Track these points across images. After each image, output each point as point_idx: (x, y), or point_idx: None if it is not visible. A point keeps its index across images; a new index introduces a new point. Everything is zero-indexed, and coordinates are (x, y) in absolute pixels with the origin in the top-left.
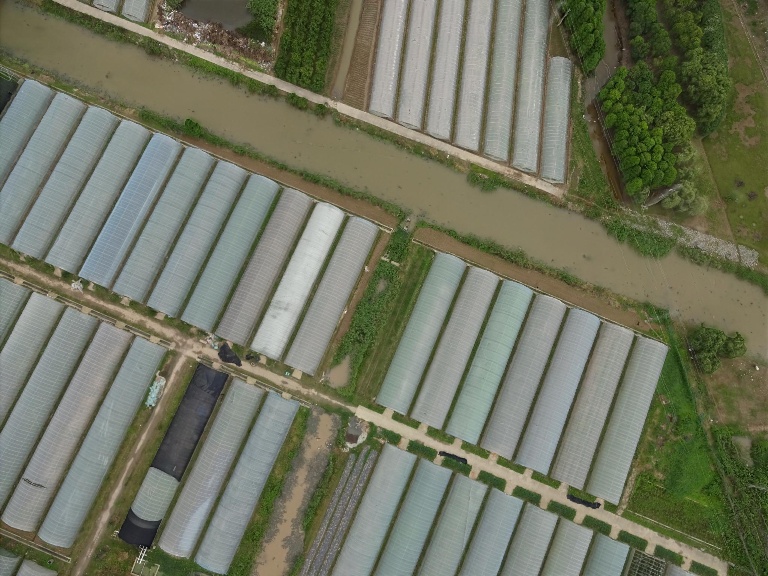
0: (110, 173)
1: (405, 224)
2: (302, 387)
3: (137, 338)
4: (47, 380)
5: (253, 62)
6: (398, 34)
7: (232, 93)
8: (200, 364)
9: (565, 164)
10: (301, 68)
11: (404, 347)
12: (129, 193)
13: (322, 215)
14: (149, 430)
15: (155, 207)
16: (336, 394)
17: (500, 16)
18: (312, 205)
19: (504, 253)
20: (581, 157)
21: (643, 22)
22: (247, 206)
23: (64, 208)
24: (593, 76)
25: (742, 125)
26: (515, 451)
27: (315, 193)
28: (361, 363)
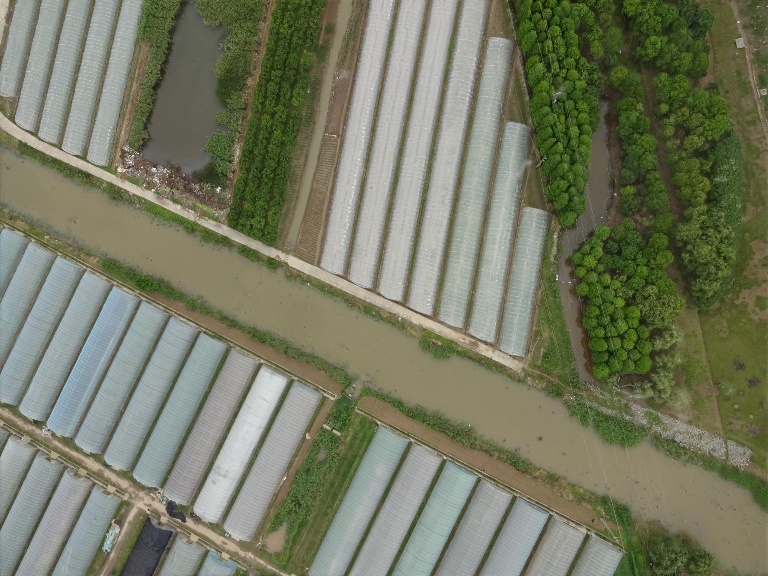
0: (72, 327)
1: (350, 390)
2: (240, 549)
3: (94, 489)
4: (19, 522)
5: (209, 209)
6: (355, 179)
7: (188, 242)
8: (147, 520)
9: (528, 333)
10: (252, 220)
11: (337, 524)
12: (89, 348)
13: (264, 382)
14: (105, 573)
15: (113, 361)
16: (271, 560)
17: (469, 157)
18: (258, 366)
19: (450, 432)
20: (548, 326)
21: (637, 169)
22: (193, 368)
23: (35, 358)
24: (573, 228)
25: (753, 294)
26: None
27: (262, 353)
28: (296, 533)
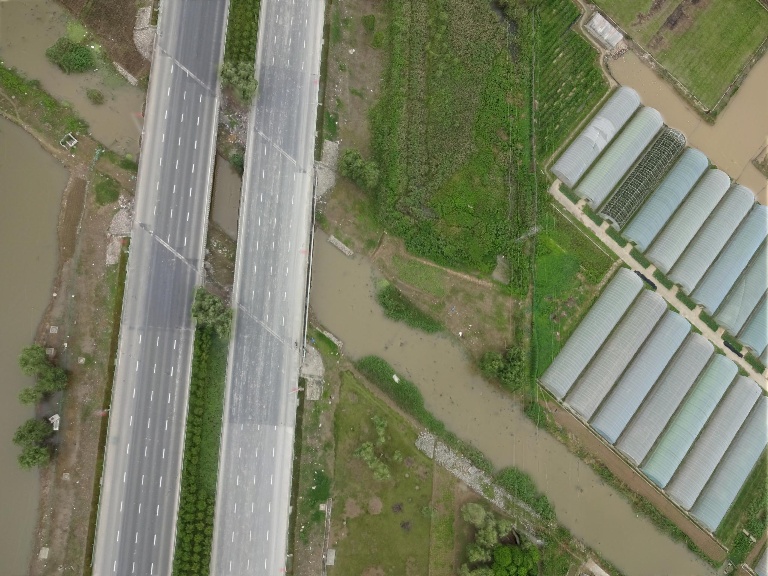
0: None
1: (728, 569)
2: None
3: None
4: None
5: None
6: None
7: None
8: None
9: None
10: None
11: None
12: None
13: None
14: None
15: None
16: None
17: None
18: None
19: (658, 516)
20: None
21: None
22: None
23: None
24: None
25: None
26: (687, 338)
27: None
28: None
